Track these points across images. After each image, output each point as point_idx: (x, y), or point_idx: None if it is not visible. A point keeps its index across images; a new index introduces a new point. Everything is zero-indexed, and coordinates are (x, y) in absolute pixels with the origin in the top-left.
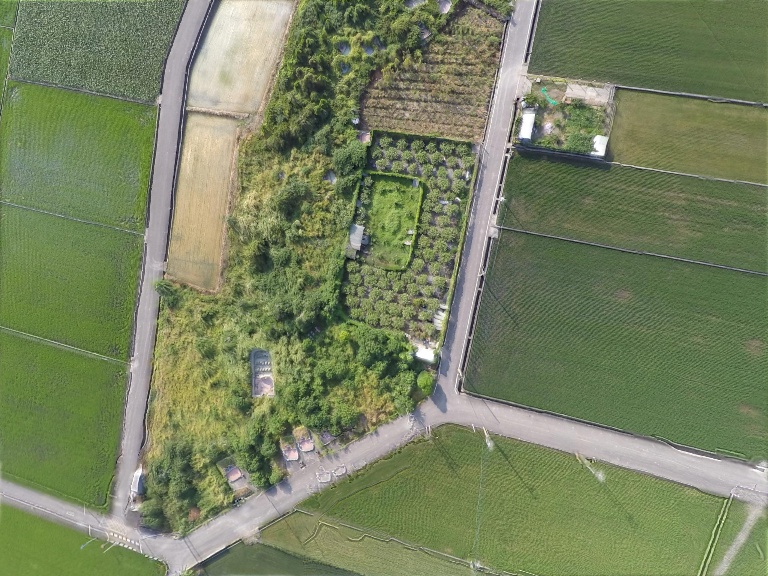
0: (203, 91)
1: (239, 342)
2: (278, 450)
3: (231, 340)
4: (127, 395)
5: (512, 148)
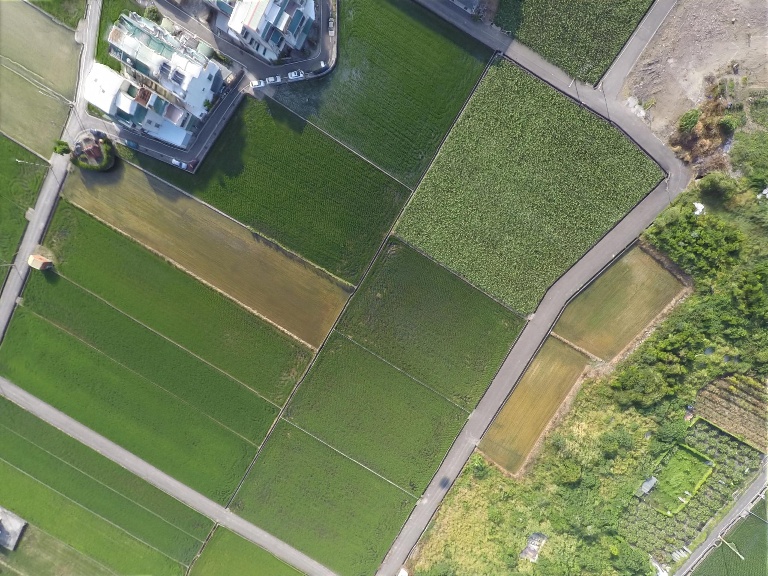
0: (571, 325)
1: (528, 525)
2: None
3: (522, 521)
4: (407, 519)
5: None
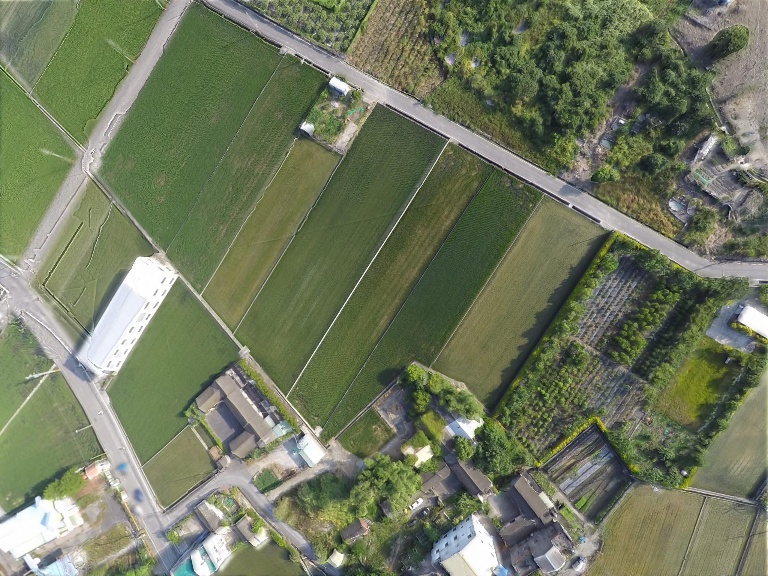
0: None
1: None
2: None
3: None
4: None
5: None
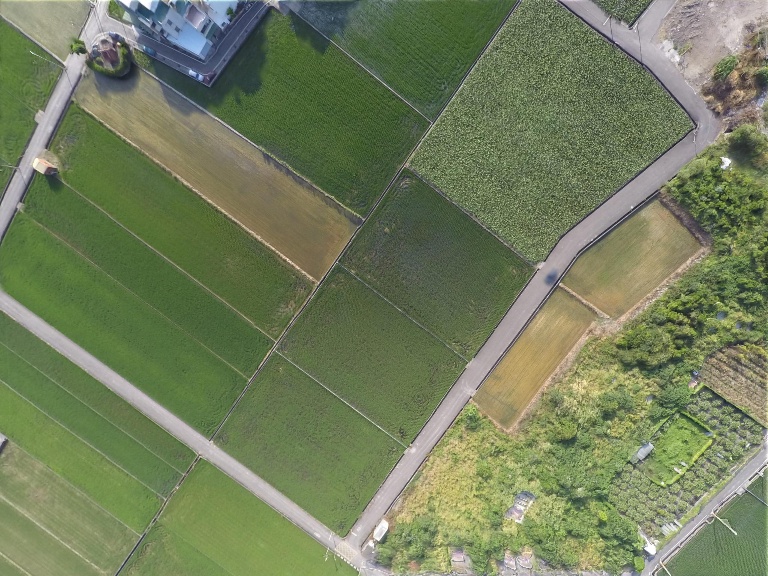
0: (581, 277)
1: (517, 482)
2: None
3: (512, 478)
4: (393, 468)
5: None
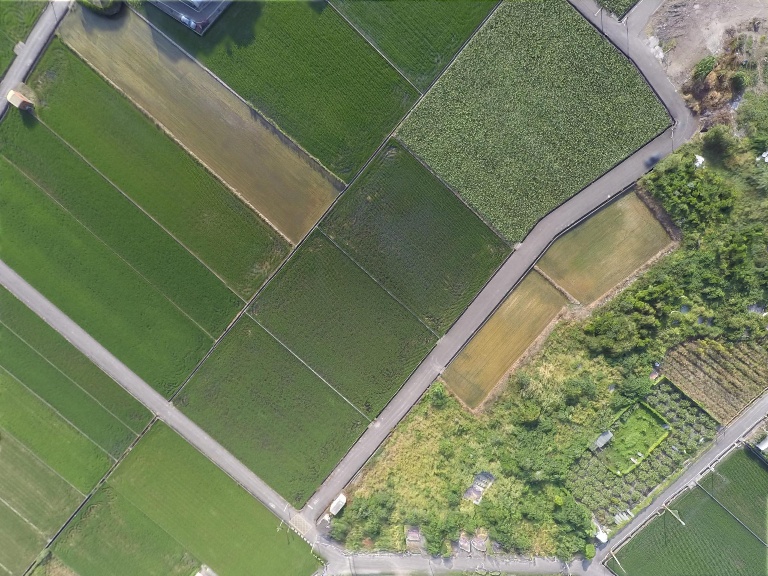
0: (556, 262)
1: (478, 462)
2: None
3: (473, 458)
4: (356, 441)
5: (743, 443)
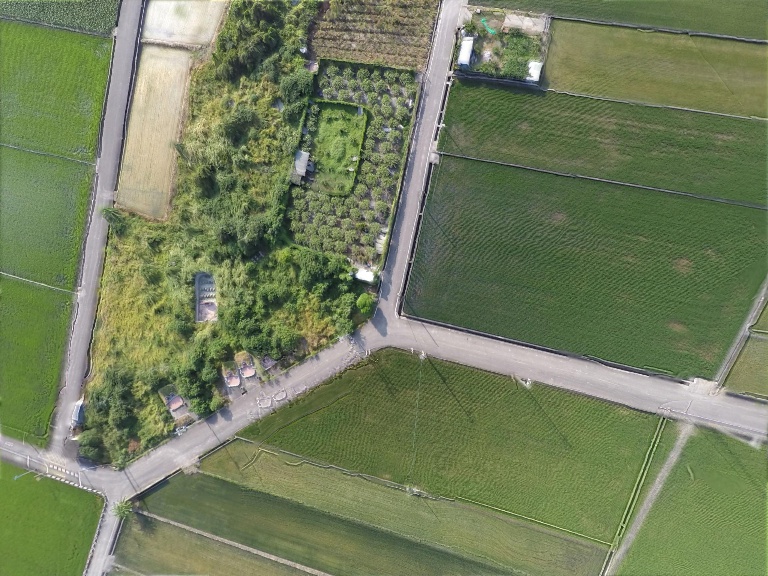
0: (158, 24)
1: (184, 267)
2: (220, 376)
3: (176, 265)
4: (73, 325)
5: (453, 76)
